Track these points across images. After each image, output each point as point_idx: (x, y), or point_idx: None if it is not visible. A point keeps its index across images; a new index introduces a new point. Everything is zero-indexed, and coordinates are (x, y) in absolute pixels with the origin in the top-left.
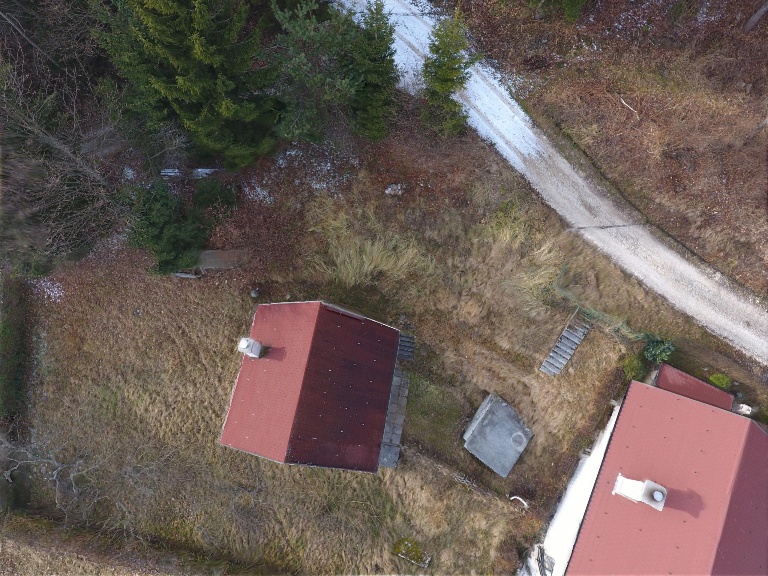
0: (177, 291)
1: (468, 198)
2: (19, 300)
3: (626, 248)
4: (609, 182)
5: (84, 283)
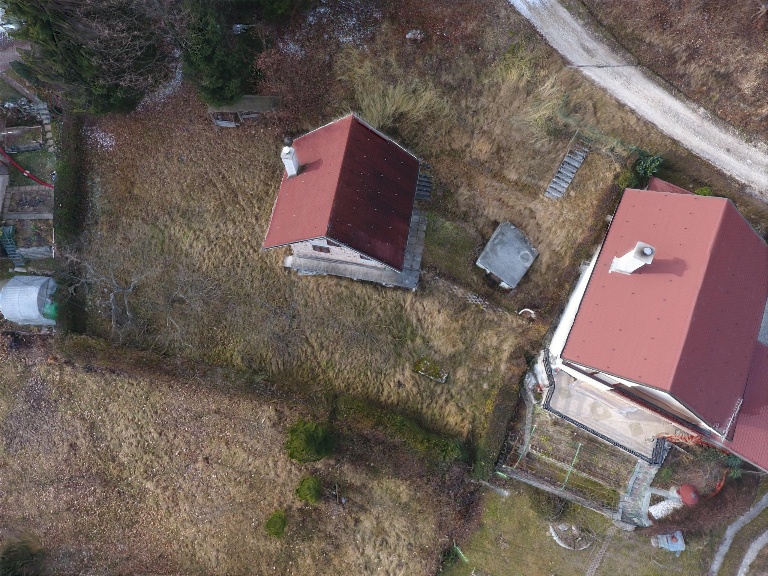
0: (218, 139)
1: (479, 44)
2: (76, 146)
3: (620, 84)
4: (605, 28)
5: (134, 133)
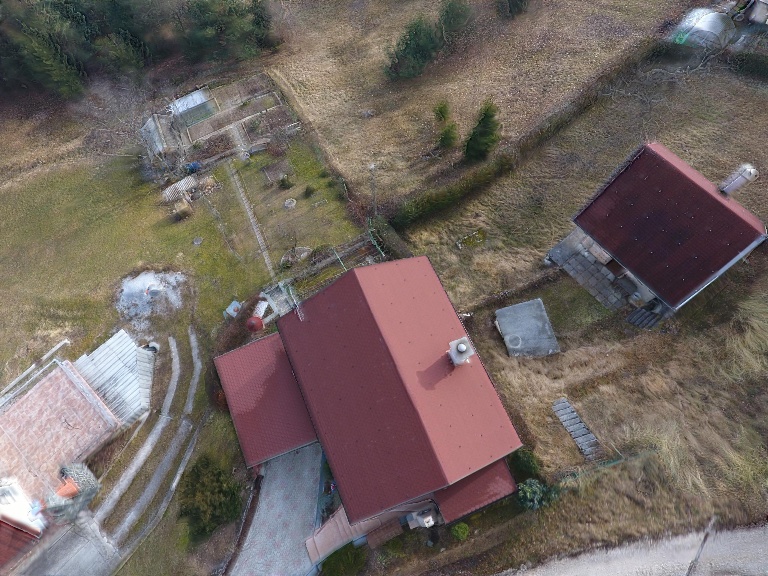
0: None
1: None
2: None
3: (653, 567)
4: None
5: None
